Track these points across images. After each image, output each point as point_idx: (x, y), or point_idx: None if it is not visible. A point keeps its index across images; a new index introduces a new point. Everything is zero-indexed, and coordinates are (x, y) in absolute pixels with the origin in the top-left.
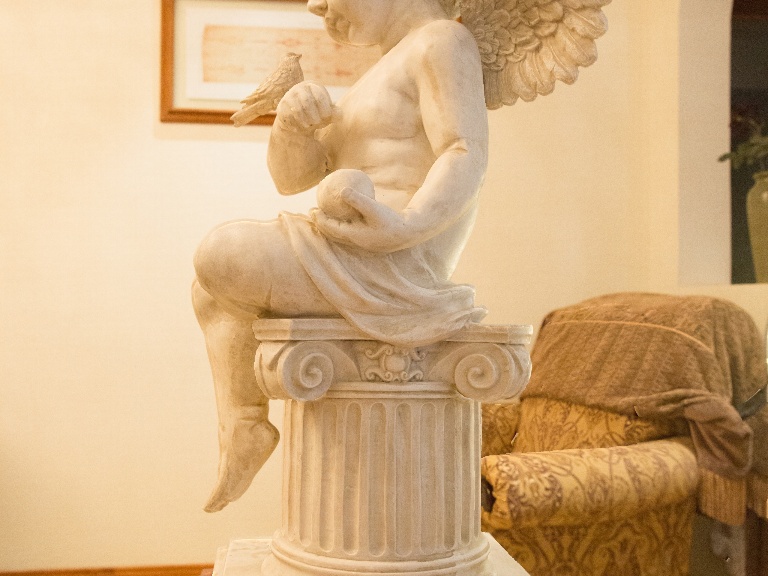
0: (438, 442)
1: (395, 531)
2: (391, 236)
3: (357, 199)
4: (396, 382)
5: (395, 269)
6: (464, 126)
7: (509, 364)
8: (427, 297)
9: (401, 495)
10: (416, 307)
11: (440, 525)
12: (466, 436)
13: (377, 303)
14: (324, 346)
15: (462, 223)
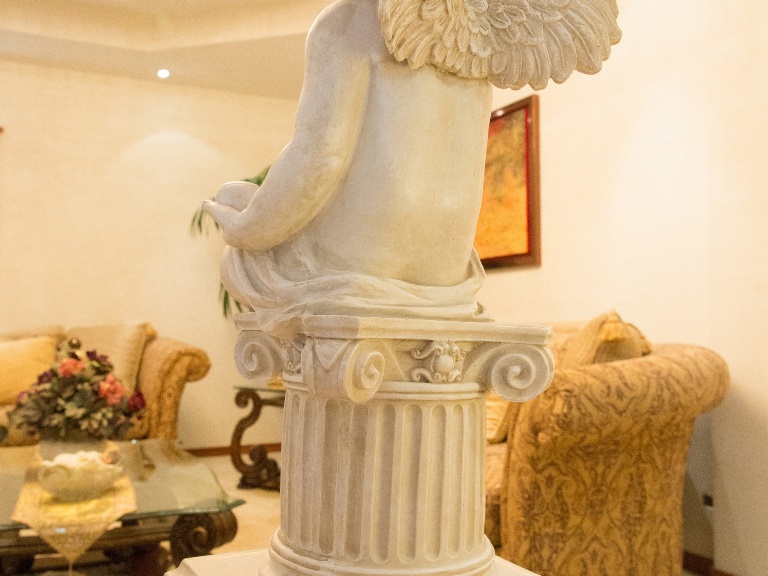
0: (318, 438)
1: (287, 515)
2: (230, 236)
3: (207, 209)
4: (289, 372)
5: (270, 264)
6: (299, 113)
7: (305, 358)
8: (283, 289)
9: (294, 483)
10: (282, 299)
11: (315, 524)
12: (364, 441)
13: (254, 297)
14: (263, 336)
15: (356, 208)
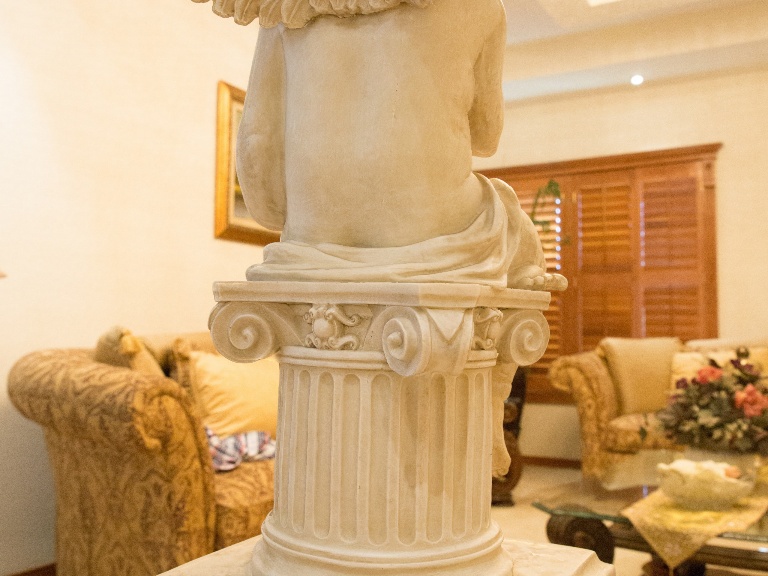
0: None
1: None
2: None
3: None
4: None
5: None
6: None
7: None
8: None
9: None
10: None
11: None
12: None
13: None
14: None
15: None
